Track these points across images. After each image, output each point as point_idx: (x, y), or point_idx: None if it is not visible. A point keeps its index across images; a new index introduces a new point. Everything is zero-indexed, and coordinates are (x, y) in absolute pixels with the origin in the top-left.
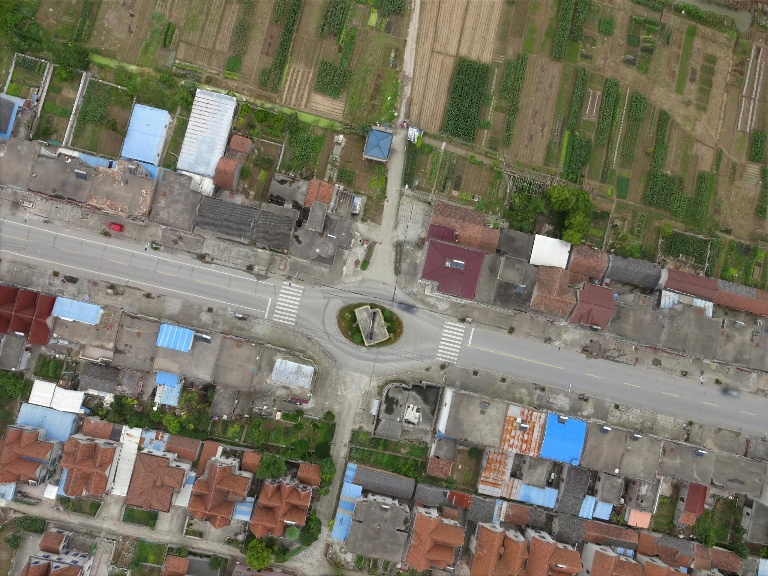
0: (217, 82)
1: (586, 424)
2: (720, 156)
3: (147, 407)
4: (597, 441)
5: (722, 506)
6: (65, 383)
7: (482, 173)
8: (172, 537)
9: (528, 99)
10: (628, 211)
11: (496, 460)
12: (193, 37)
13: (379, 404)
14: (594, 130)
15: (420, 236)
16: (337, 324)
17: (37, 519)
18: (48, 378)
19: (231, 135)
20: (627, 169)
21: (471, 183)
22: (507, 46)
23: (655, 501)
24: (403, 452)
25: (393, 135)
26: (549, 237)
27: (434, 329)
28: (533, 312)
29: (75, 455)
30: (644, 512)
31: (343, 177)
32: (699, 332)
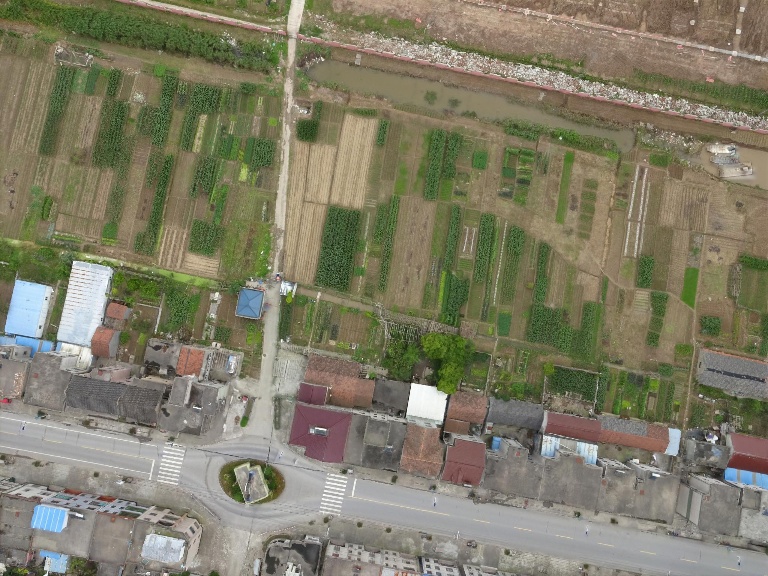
0: (95, 250)
1: None
2: (606, 285)
3: (40, 573)
4: None
5: None
6: None
7: (359, 320)
8: None
9: (402, 242)
10: (511, 349)
11: None
12: (70, 208)
13: (260, 564)
14: (472, 268)
15: (298, 389)
16: (219, 482)
17: None
18: None
19: (109, 302)
20: (508, 305)
21: (348, 331)
22: (379, 190)
23: None
24: None
25: (264, 293)
26: (426, 385)
27: (316, 482)
28: (403, 471)
29: None
30: None
31: (219, 335)
32: (578, 482)
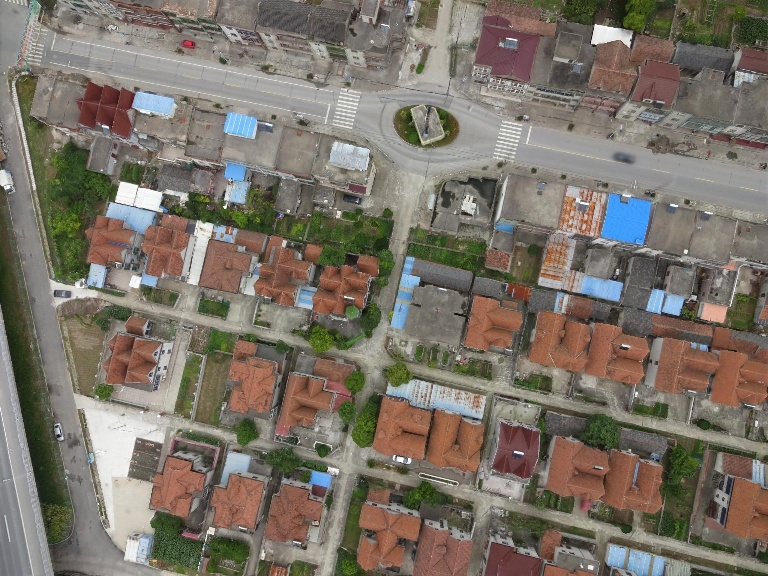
0: None
1: (651, 204)
2: None
3: (218, 208)
4: (663, 221)
5: None
6: (146, 185)
7: None
8: (242, 328)
9: None
10: (697, 0)
11: (556, 250)
12: None
13: (436, 197)
14: None
15: (475, 37)
16: (394, 126)
17: (124, 308)
18: (132, 183)
19: None
20: None
21: None
22: None
23: (731, 294)
24: (461, 249)
25: None
26: (609, 27)
27: (491, 128)
28: (591, 92)
29: (154, 239)
30: (719, 306)
31: None
32: None
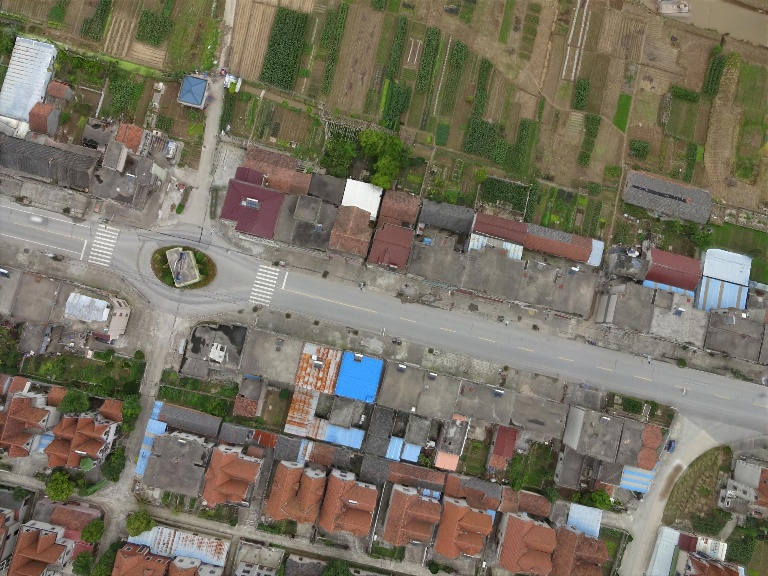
0: (40, 32)
1: (384, 363)
2: (543, 104)
3: None
4: (394, 379)
5: (537, 452)
6: None
7: (301, 120)
8: None
9: (349, 48)
10: (447, 158)
11: (300, 399)
12: None
13: (185, 343)
14: (415, 78)
15: None
16: (151, 266)
17: None
18: None
19: None
20: (447, 117)
21: (289, 130)
22: None
23: (462, 443)
24: (213, 392)
25: (207, 81)
26: (362, 182)
27: (248, 272)
28: (332, 251)
29: None
30: (452, 454)
31: (161, 123)
32: (501, 273)
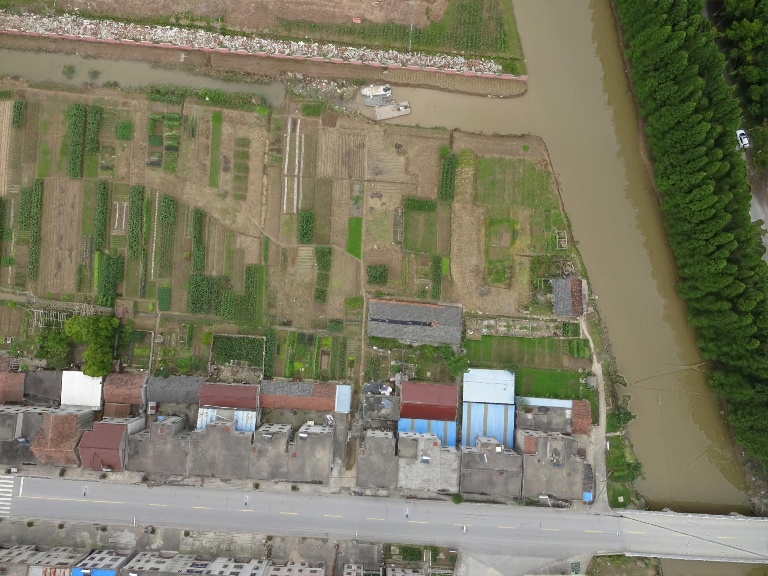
0: None
1: (117, 572)
2: (266, 245)
3: None
4: None
5: None
6: None
7: (12, 312)
8: None
9: (51, 225)
10: (174, 323)
11: None
12: None
13: None
14: (126, 244)
15: None
16: None
17: None
18: None
19: None
20: (167, 278)
21: (2, 325)
22: (21, 174)
23: None
24: None
25: None
26: (79, 371)
27: None
28: (43, 463)
29: None
30: None
31: None
32: (227, 453)
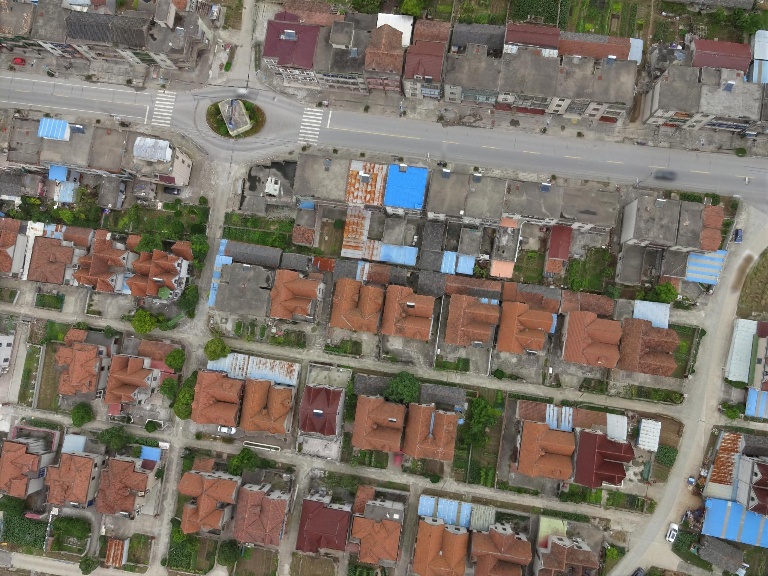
0: None
1: (428, 172)
2: None
3: (51, 209)
4: (440, 186)
5: (595, 256)
6: None
7: None
8: (77, 318)
9: None
10: None
11: (353, 222)
12: None
13: (243, 182)
14: None
15: None
16: (206, 121)
17: None
18: None
19: None
20: None
21: None
22: None
23: (516, 250)
24: (272, 229)
25: None
26: (392, 15)
27: (294, 116)
28: (369, 73)
29: None
30: (506, 262)
31: None
32: (537, 72)
